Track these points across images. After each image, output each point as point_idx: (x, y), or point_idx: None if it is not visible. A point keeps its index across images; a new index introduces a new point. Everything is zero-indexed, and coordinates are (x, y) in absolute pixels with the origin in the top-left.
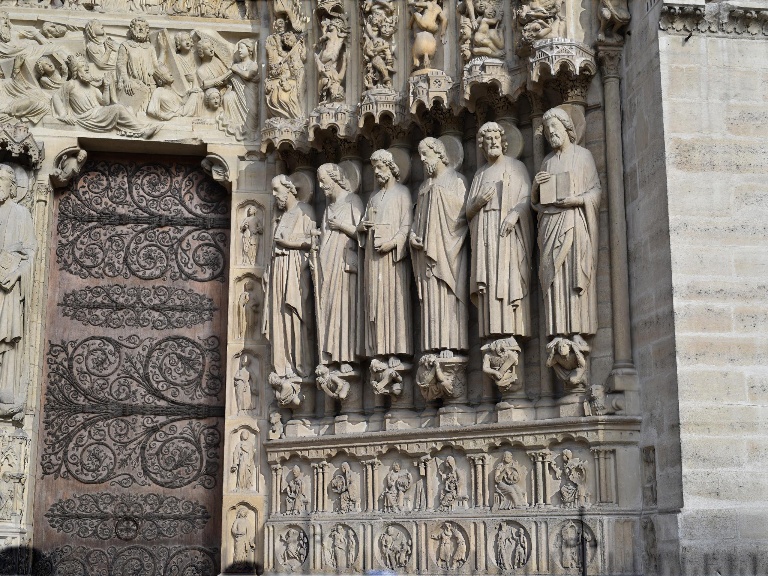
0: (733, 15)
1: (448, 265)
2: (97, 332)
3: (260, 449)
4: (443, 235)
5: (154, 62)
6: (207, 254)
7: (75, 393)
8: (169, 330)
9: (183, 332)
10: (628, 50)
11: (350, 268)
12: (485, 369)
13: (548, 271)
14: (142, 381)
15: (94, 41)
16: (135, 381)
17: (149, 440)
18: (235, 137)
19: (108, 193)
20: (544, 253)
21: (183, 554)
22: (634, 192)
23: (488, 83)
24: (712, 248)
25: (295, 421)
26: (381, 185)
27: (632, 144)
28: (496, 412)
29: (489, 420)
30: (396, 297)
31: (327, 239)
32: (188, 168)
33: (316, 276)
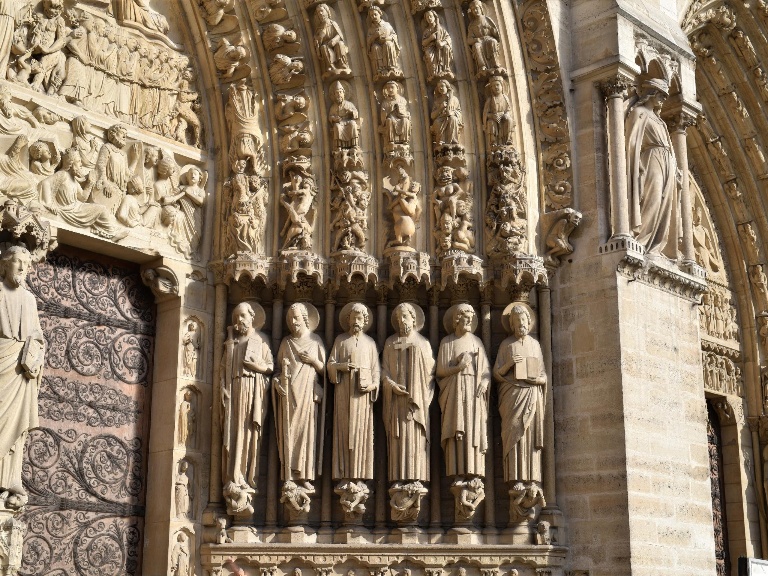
0: (652, 270)
1: (424, 412)
2: (40, 423)
3: (195, 551)
4: (423, 387)
5: (126, 169)
6: (135, 358)
7: None
8: (101, 428)
9: (112, 431)
10: (566, 272)
11: (318, 399)
12: (465, 502)
13: (517, 430)
14: (77, 476)
15: (83, 137)
16: (71, 475)
17: (81, 536)
18: (184, 255)
19: (55, 283)
20: (515, 416)
21: None
22: (568, 379)
23: (474, 274)
24: (642, 432)
25: (245, 528)
26: (352, 332)
27: (567, 343)
28: (454, 535)
29: (443, 541)
30: (370, 431)
31: (299, 370)
32: (122, 272)
33: (288, 401)
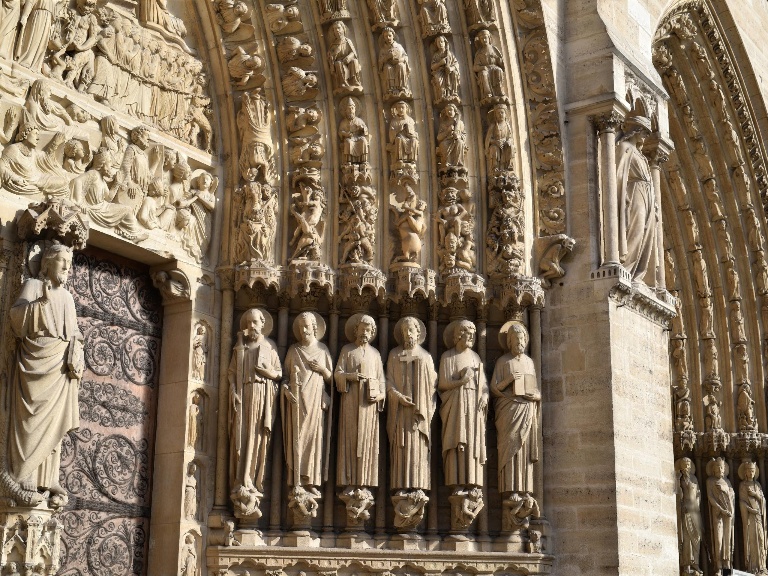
0: (636, 297)
1: None
2: None
3: (202, 553)
4: (428, 399)
5: (147, 171)
6: (143, 359)
7: None
8: (113, 428)
9: (123, 431)
10: (557, 295)
11: (326, 406)
12: (467, 510)
13: (514, 444)
14: (91, 476)
15: (111, 137)
16: (85, 475)
17: (93, 535)
18: (196, 259)
19: (74, 282)
20: (513, 430)
21: None
22: (557, 396)
23: (477, 293)
24: None
25: (252, 531)
26: (359, 343)
27: (557, 362)
28: (453, 542)
29: (440, 548)
30: (376, 440)
31: (309, 378)
32: (133, 273)
33: (298, 408)
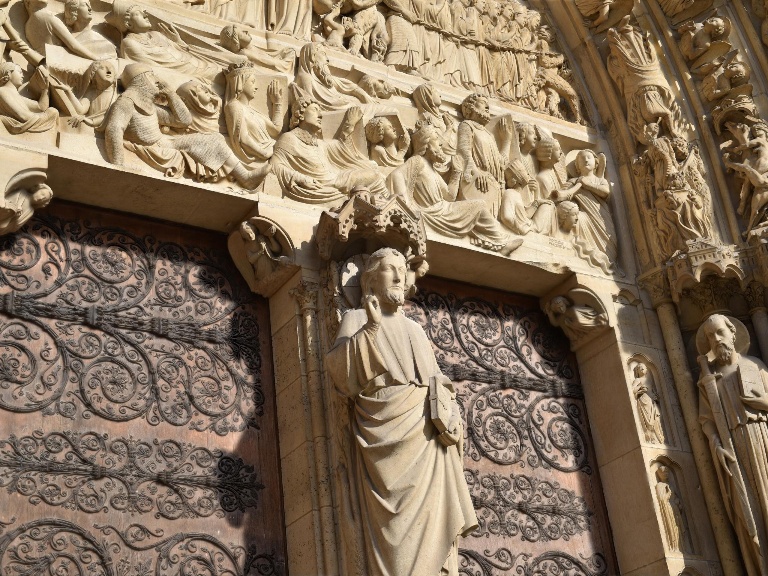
0: None
1: None
2: None
3: None
4: None
5: None
6: (564, 433)
7: None
8: (543, 542)
9: (560, 546)
10: None
11: None
12: None
13: None
14: None
15: (432, 111)
16: None
17: None
18: (603, 269)
19: (431, 333)
20: None
21: None
22: None
23: None
24: None
25: None
26: None
27: None
28: None
29: None
30: None
31: None
32: (517, 311)
33: None
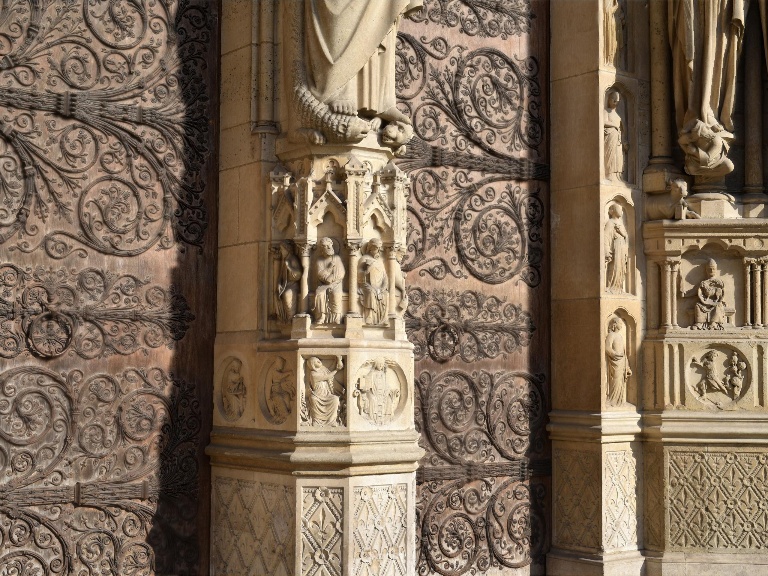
0: None
1: None
2: None
3: (635, 232)
4: None
5: None
6: None
7: None
8: (481, 38)
9: (497, 44)
10: None
11: None
12: None
13: None
14: (452, 113)
15: None
16: (443, 112)
17: (463, 207)
18: None
19: None
20: None
21: (507, 383)
22: None
23: None
24: None
25: (718, 195)
26: None
27: None
28: None
29: None
30: None
31: None
32: None
33: None
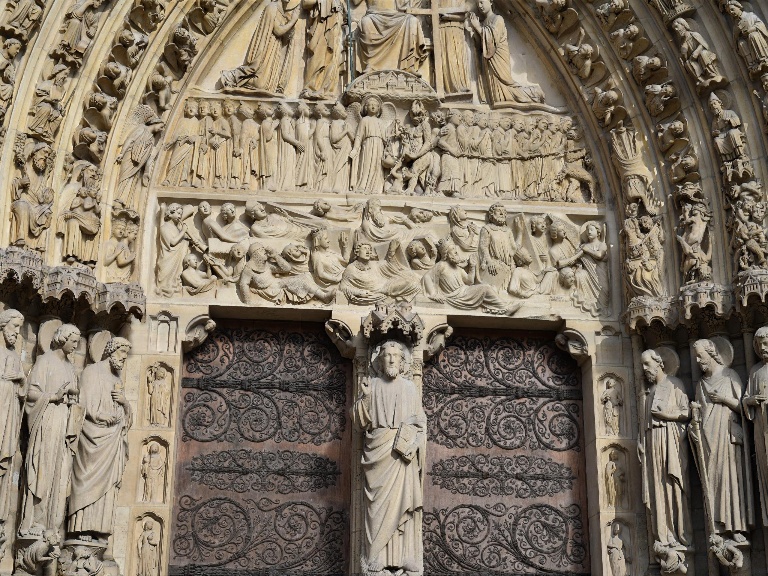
0: None
1: None
2: (465, 500)
3: None
4: None
5: (512, 244)
6: (562, 424)
7: (449, 560)
8: (532, 498)
9: (545, 500)
10: None
11: (736, 440)
12: None
13: None
14: (511, 548)
15: (459, 225)
16: (504, 548)
17: None
18: (590, 313)
19: (467, 366)
20: None
21: None
22: None
23: None
24: None
25: None
26: (764, 360)
27: None
28: None
29: None
30: None
31: (710, 412)
32: (538, 342)
33: (701, 447)
